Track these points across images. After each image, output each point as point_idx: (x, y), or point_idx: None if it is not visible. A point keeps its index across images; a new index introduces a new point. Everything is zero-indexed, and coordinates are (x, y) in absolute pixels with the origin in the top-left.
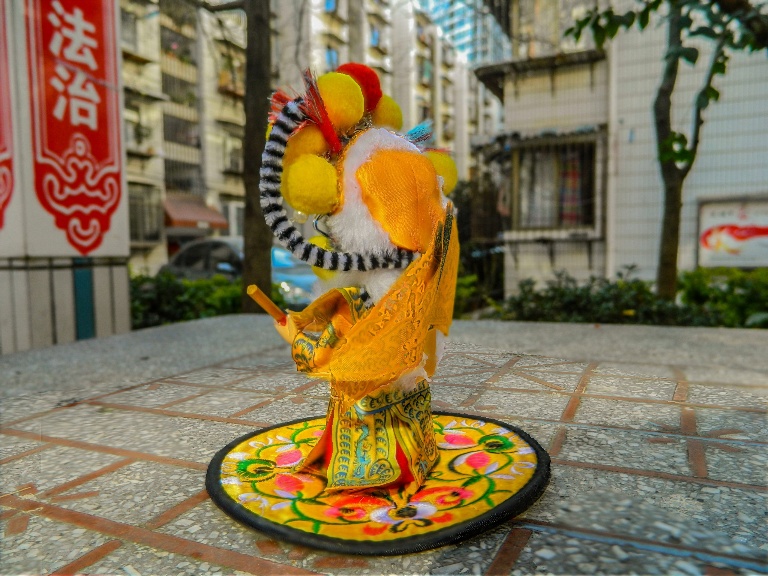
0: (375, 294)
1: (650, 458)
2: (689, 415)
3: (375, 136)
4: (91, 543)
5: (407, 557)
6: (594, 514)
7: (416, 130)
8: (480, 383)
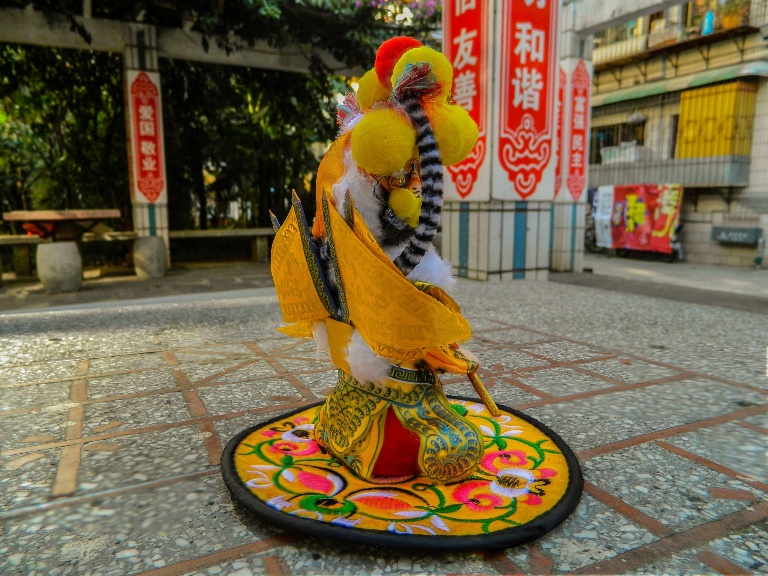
0: None
1: None
2: None
3: None
4: None
5: None
6: (172, 497)
7: None
8: None
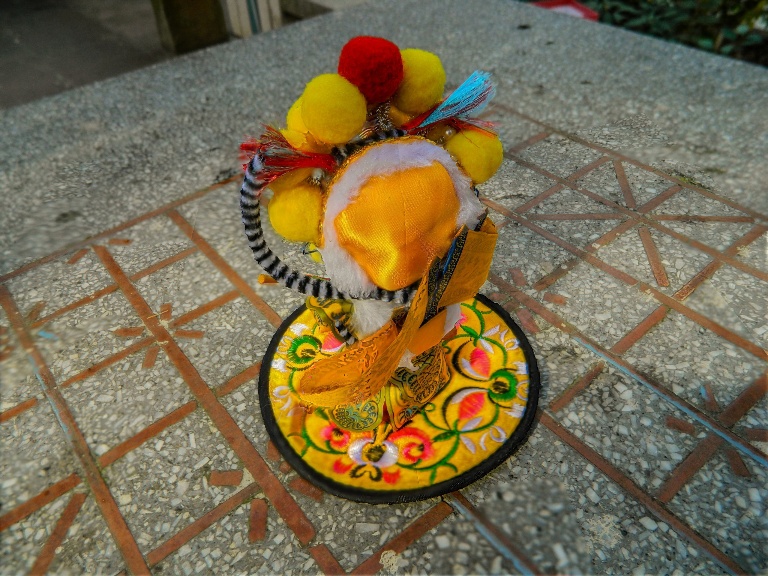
0: (358, 316)
1: (639, 452)
2: (759, 389)
3: (367, 167)
4: (181, 398)
5: (349, 502)
6: (517, 511)
7: (461, 97)
8: (585, 244)
